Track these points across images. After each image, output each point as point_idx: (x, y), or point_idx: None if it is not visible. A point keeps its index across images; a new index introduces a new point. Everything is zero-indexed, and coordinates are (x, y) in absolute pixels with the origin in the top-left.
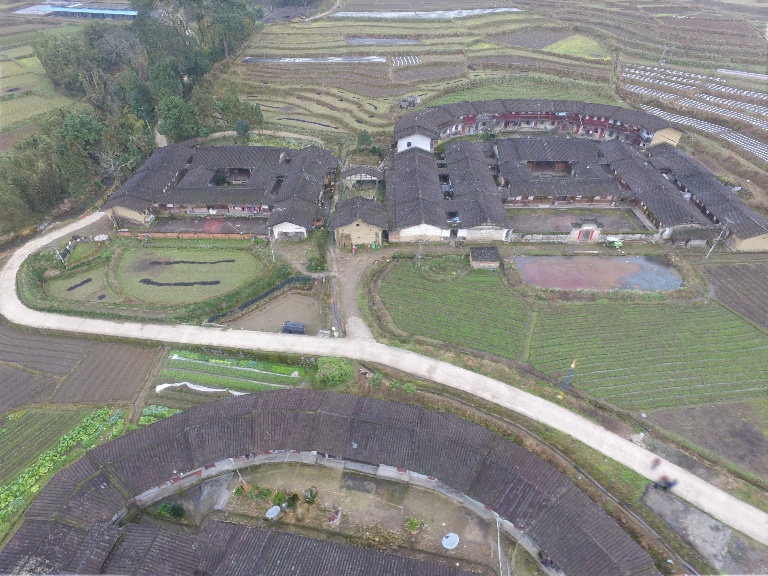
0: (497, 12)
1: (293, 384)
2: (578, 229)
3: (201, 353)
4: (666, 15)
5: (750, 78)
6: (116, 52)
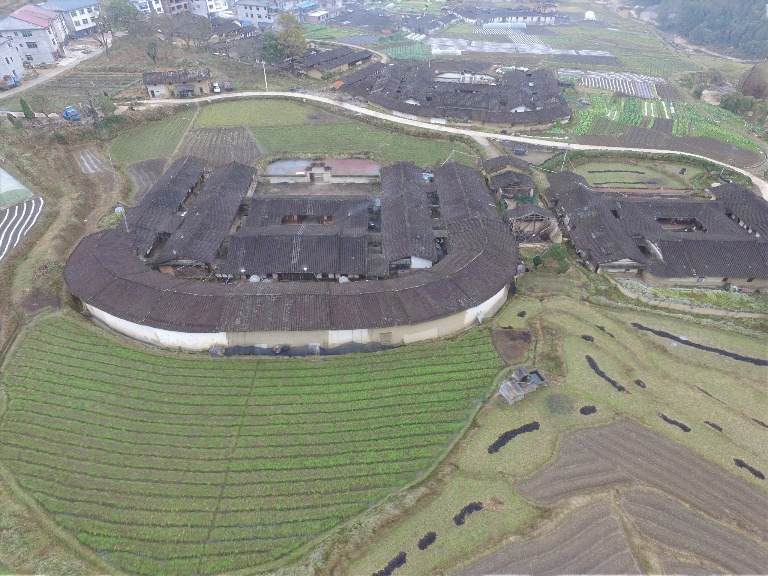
0: None
1: None
2: None
3: None
4: None
5: None
6: None
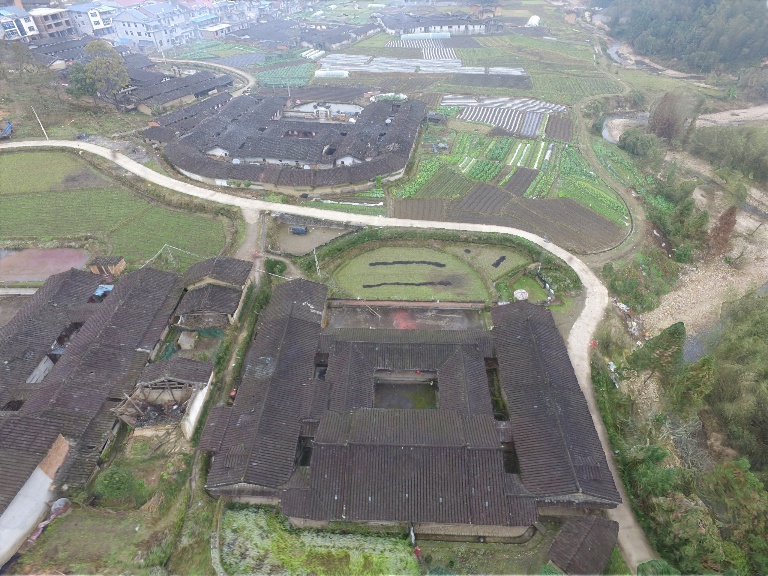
0: None
1: None
2: None
3: None
4: None
5: None
6: None
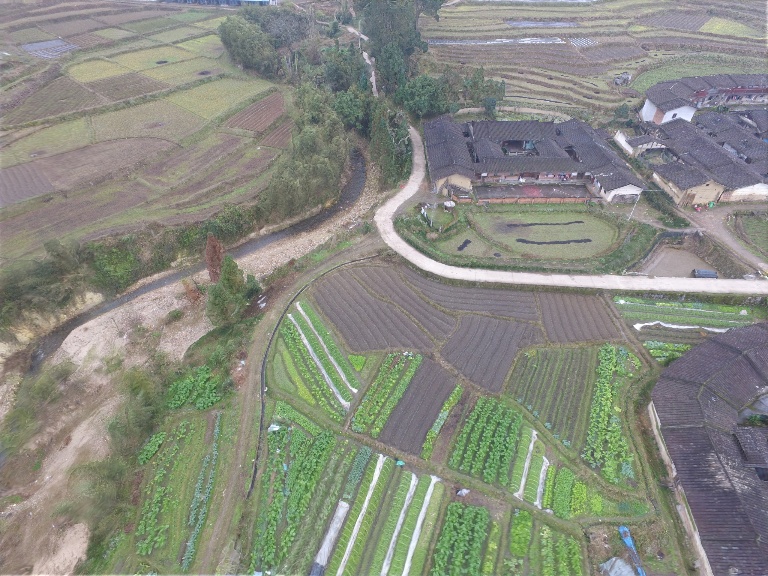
0: None
1: (750, 320)
2: None
3: (641, 298)
4: None
5: None
6: (283, 36)
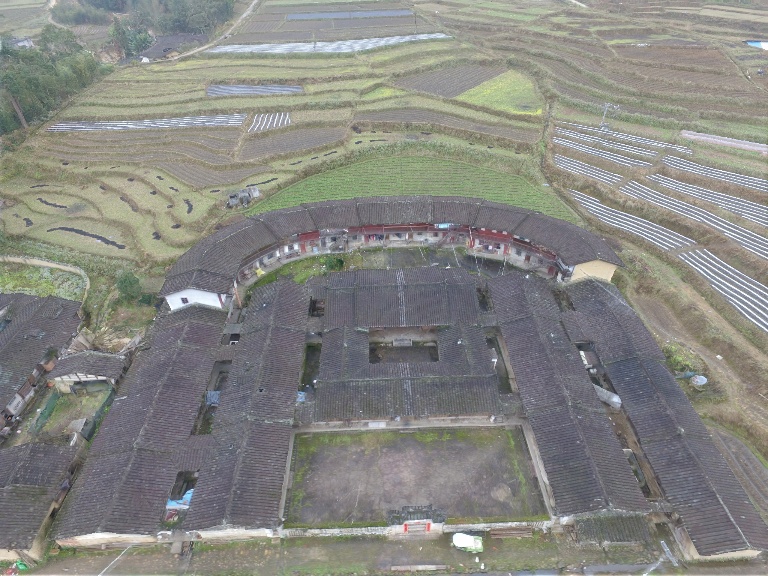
0: (417, 40)
1: None
2: (399, 524)
3: None
4: (623, 42)
5: (726, 146)
6: None
